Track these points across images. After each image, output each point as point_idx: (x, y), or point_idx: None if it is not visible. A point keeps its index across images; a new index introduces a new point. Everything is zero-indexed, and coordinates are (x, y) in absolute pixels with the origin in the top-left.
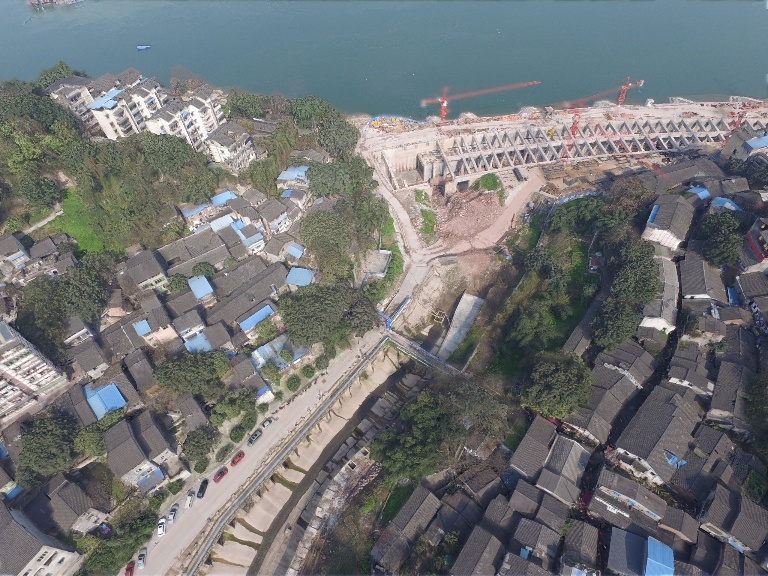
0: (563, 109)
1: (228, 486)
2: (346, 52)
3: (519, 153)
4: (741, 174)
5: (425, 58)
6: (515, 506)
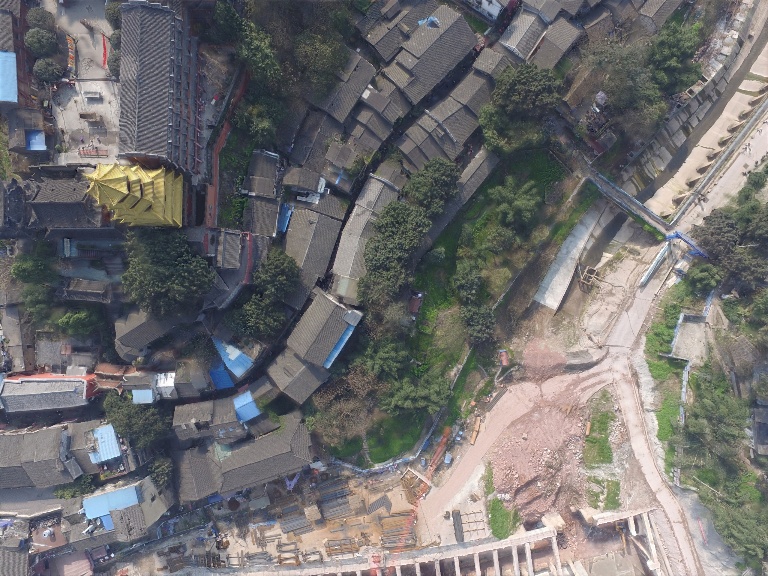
0: None
1: None
2: None
3: None
4: (161, 456)
5: None
6: None
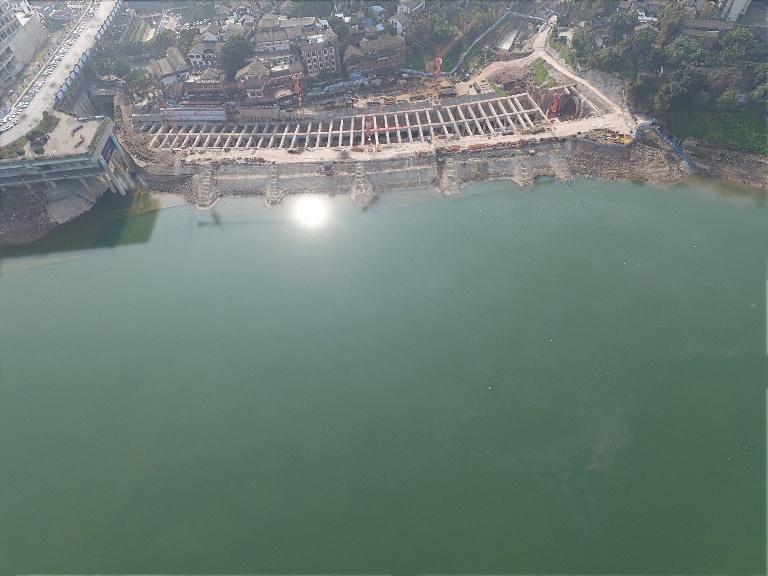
0: (412, 190)
1: None
2: None
3: (473, 114)
4: None
5: (621, 302)
6: None
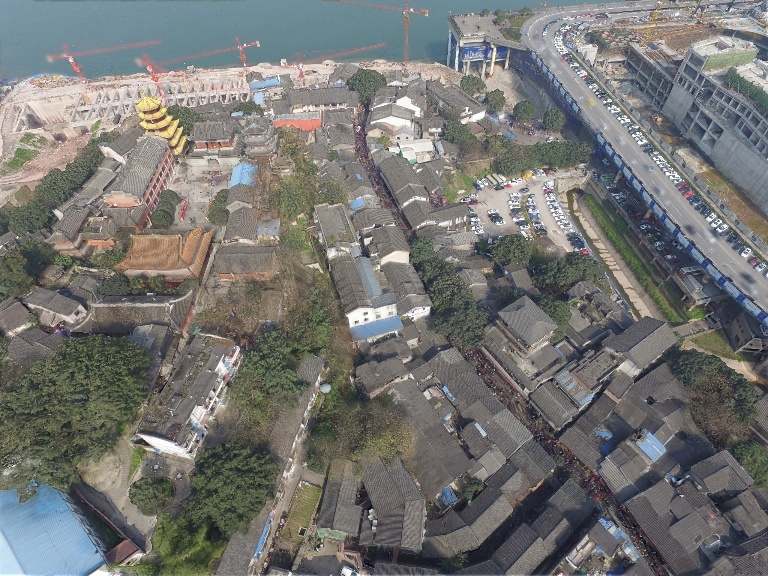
0: None
1: None
2: (74, 22)
3: None
4: None
5: (141, 27)
6: None
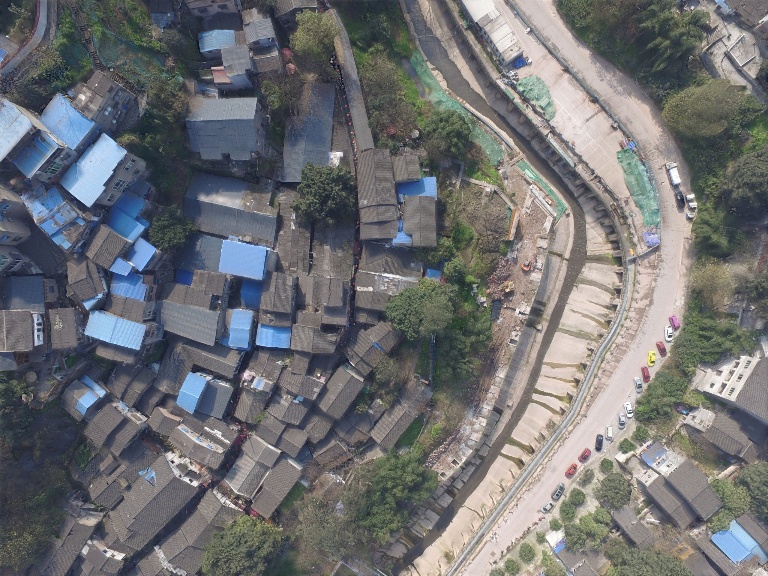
0: None
1: (575, 445)
2: None
3: None
4: None
5: None
6: (303, 434)
